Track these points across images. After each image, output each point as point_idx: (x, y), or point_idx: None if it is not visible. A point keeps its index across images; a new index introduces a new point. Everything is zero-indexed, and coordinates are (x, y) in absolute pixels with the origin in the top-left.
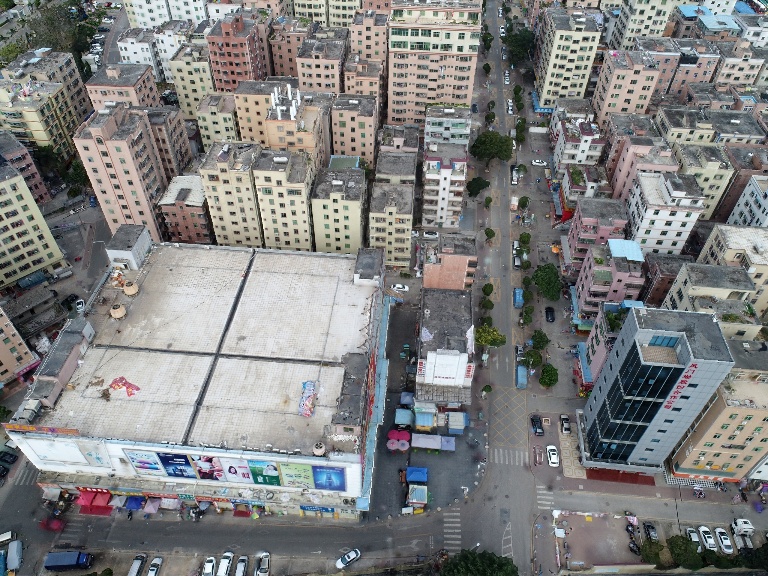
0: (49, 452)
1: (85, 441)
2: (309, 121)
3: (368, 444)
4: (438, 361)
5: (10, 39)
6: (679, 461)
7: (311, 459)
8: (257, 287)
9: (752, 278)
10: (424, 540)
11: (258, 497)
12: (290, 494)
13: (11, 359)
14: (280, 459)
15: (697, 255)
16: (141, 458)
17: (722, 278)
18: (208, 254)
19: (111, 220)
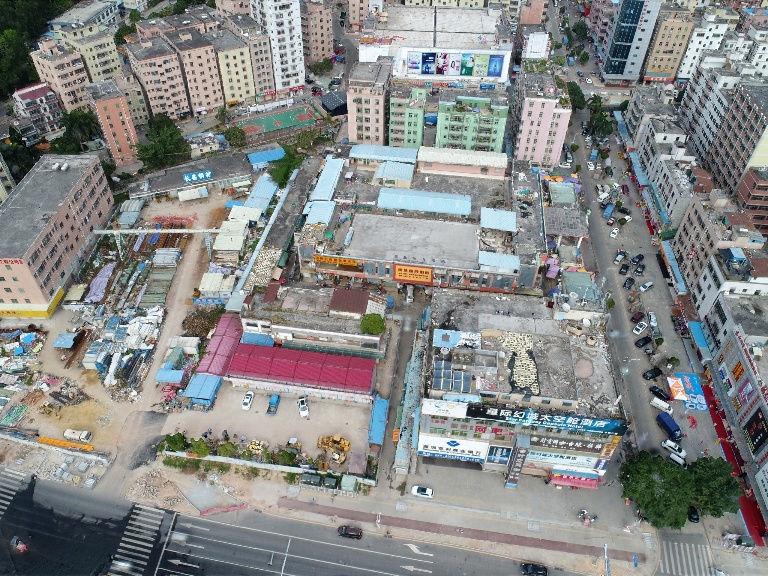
0: (373, 58)
1: (394, 46)
2: None
3: None
4: (534, 40)
5: None
6: (646, 69)
7: (491, 50)
8: (443, 16)
9: (680, 5)
10: None
11: (461, 83)
12: (475, 82)
13: (327, 49)
14: (477, 52)
15: None
16: (414, 59)
17: None
18: (413, 9)
19: (352, 5)
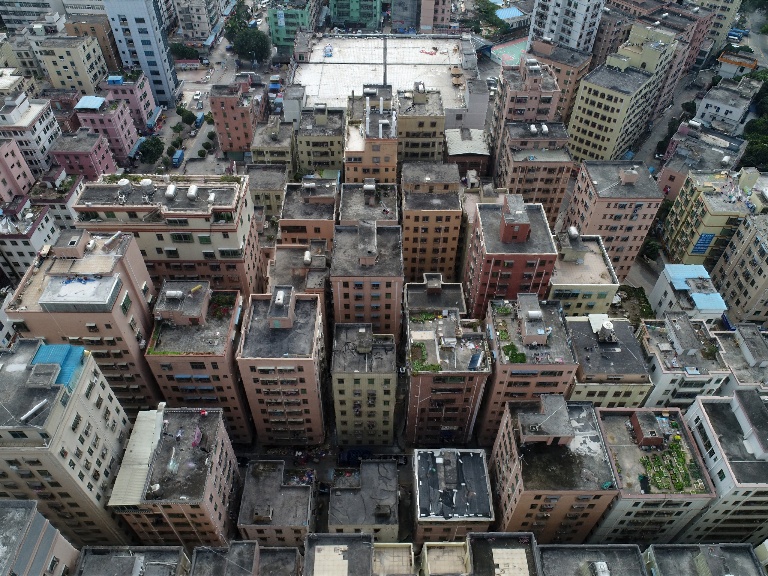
0: None
1: None
2: (356, 139)
3: None
4: None
5: None
6: None
7: None
8: None
9: None
10: None
11: None
12: None
13: None
14: None
15: None
16: None
17: (60, 43)
18: None
19: None
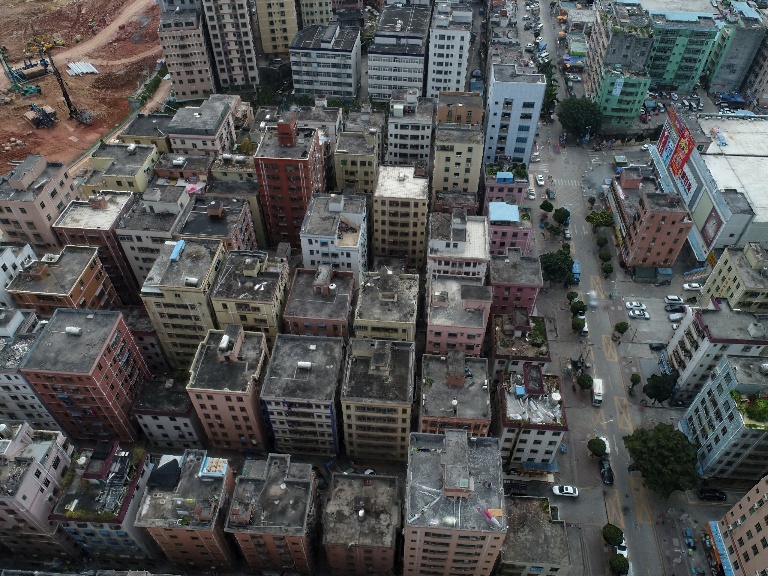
0: None
1: None
2: None
3: (663, 168)
4: None
5: None
6: None
7: None
8: None
9: None
10: (609, 154)
11: None
12: None
13: None
14: None
15: (407, 266)
16: None
17: (458, 136)
18: None
19: None
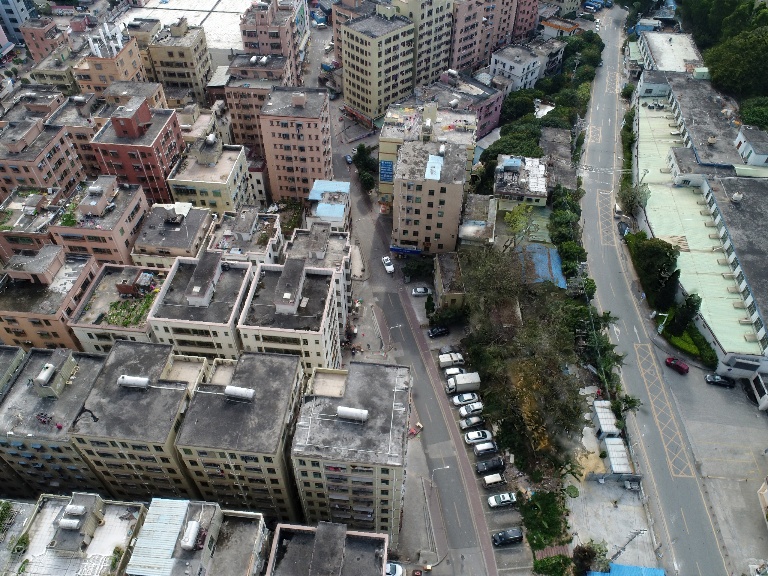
0: None
1: None
2: None
3: None
4: None
5: (686, 452)
6: None
7: None
8: None
9: None
10: None
11: None
12: None
13: None
14: None
15: None
16: None
17: None
18: None
19: None
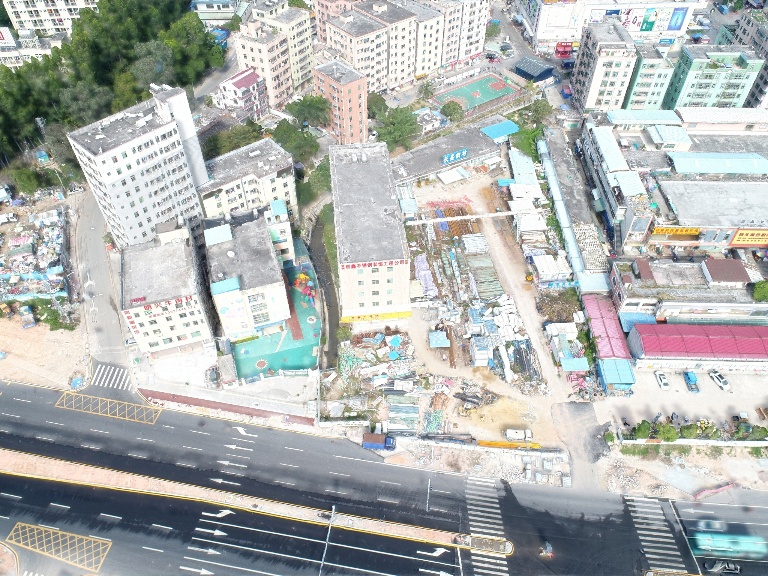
0: (554, 19)
1: (579, 5)
2: None
3: None
4: None
5: None
6: None
7: (677, 2)
8: None
9: None
10: None
11: (640, 39)
12: (653, 37)
13: None
14: (662, 5)
15: None
16: (596, 17)
17: None
18: None
19: None
